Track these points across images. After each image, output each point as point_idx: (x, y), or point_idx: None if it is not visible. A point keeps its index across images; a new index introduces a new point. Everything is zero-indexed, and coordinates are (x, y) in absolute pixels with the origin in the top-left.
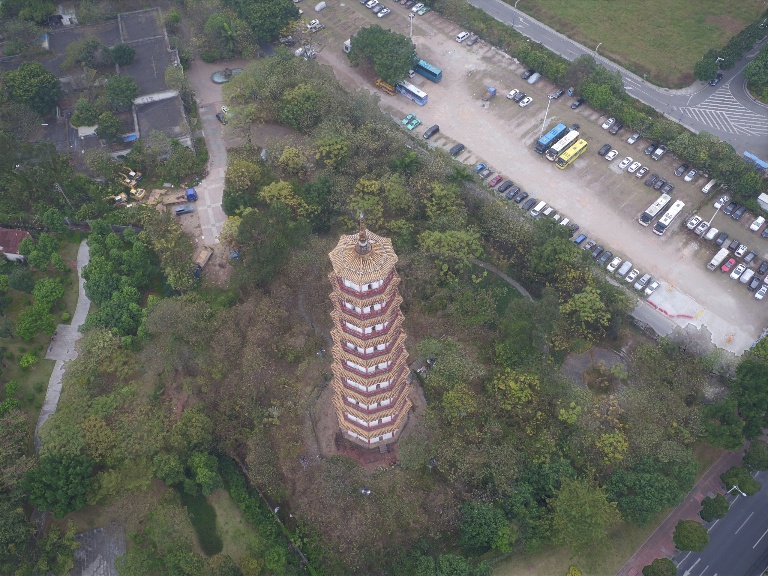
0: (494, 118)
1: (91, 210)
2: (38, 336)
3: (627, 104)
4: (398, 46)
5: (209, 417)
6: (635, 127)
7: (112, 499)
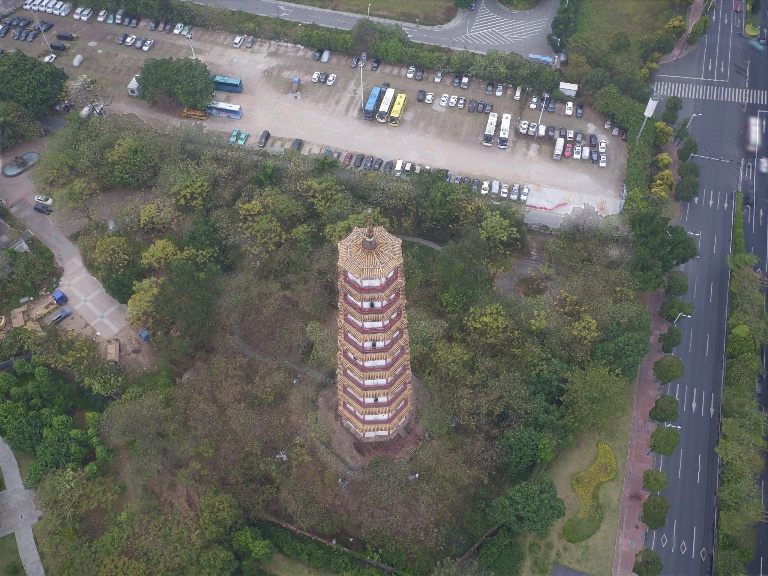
0: (312, 105)
1: None
2: None
3: None
4: (190, 70)
5: None
6: (436, 67)
7: None
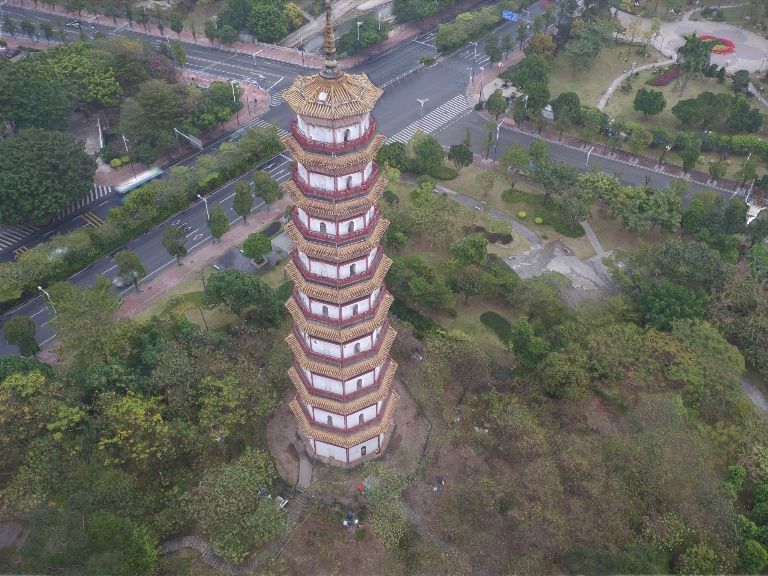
0: None
1: None
2: None
3: None
4: None
5: None
6: None
7: None
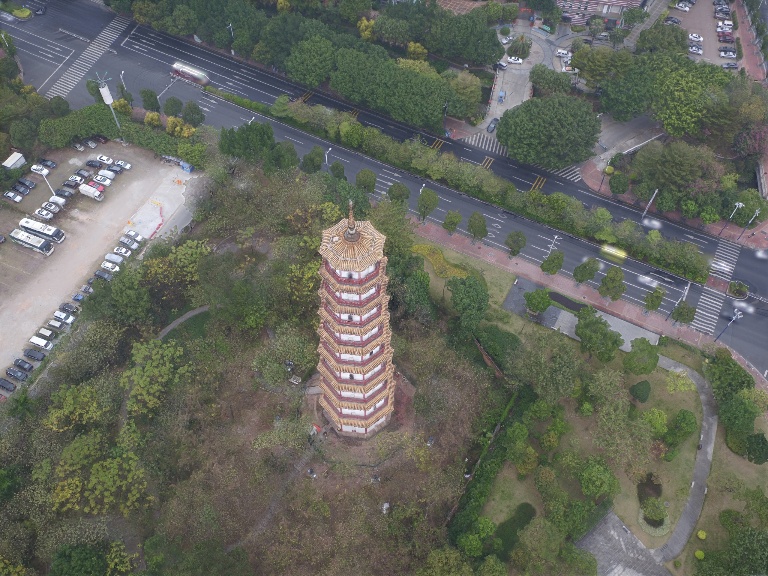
0: None
1: None
2: None
3: None
4: None
5: None
6: None
7: None
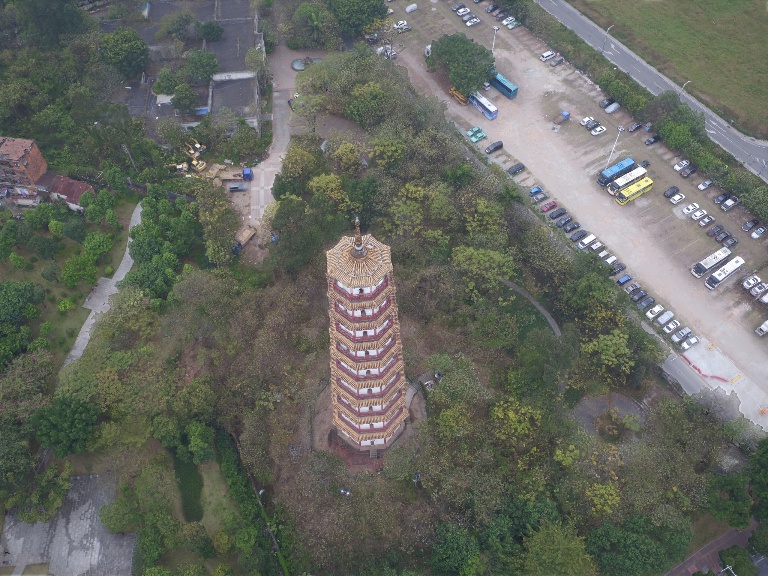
0: (562, 143)
1: (152, 174)
2: (81, 284)
3: (706, 148)
4: (477, 57)
5: (215, 390)
6: (708, 173)
7: (108, 450)
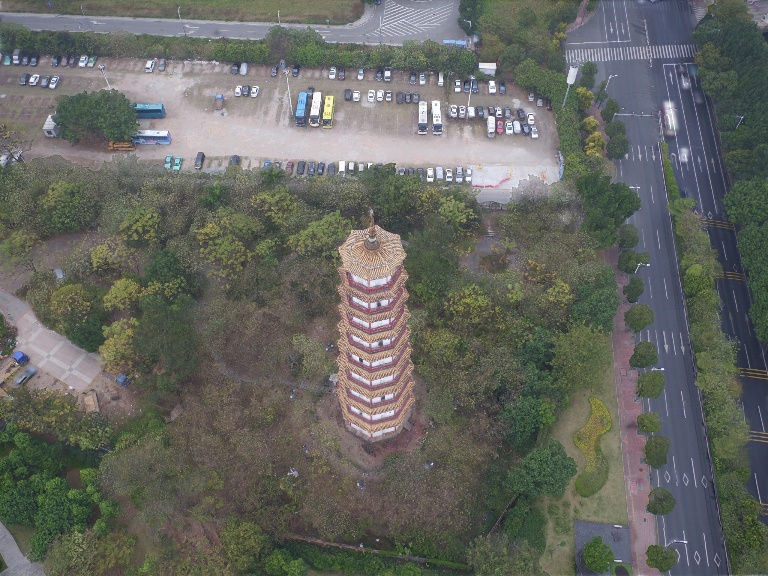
0: (241, 119)
1: None
2: None
3: None
4: (109, 102)
5: None
6: (357, 64)
7: None
